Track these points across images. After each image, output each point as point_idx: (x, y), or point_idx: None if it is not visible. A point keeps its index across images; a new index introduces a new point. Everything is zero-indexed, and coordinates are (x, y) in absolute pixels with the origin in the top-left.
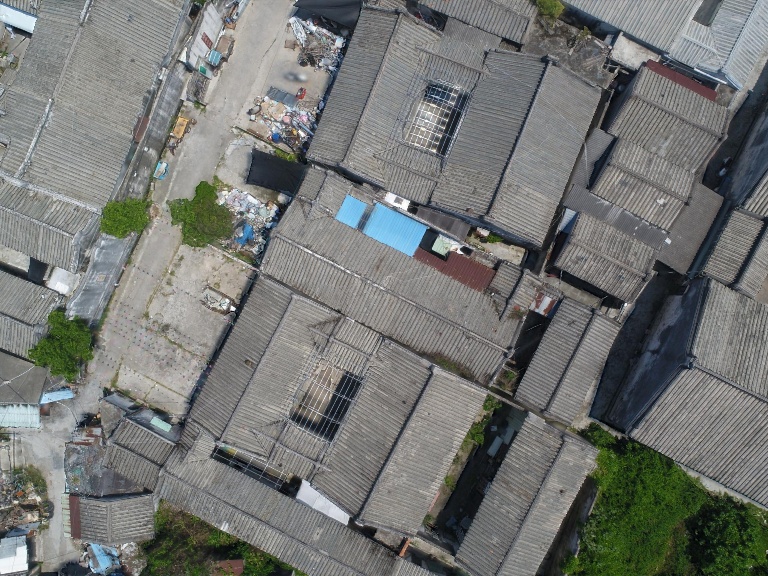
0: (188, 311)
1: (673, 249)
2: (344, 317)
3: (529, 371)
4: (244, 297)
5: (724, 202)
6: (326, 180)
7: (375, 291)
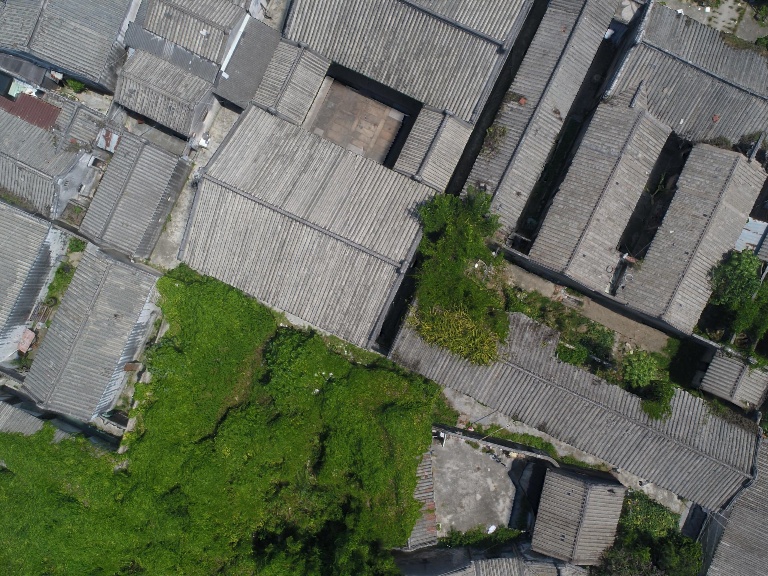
0: None
1: (232, 84)
2: None
3: (92, 204)
4: None
5: None
6: None
7: None
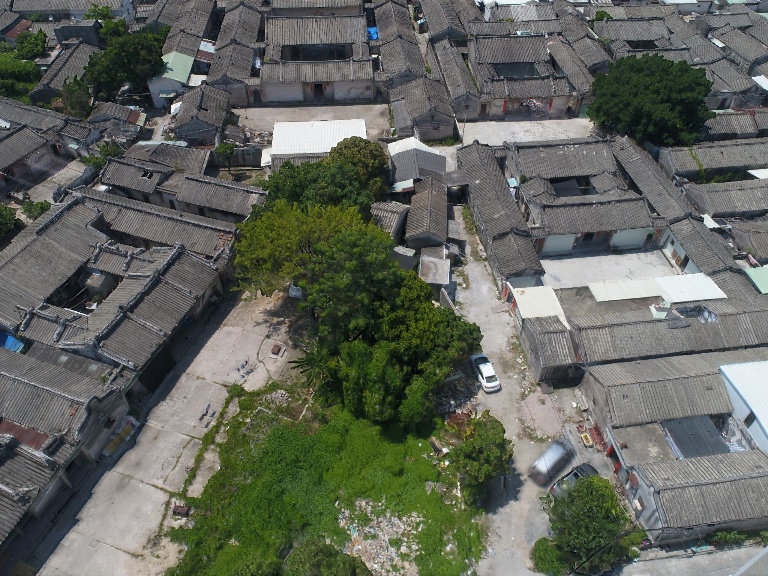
0: (47, 199)
1: None
2: None
3: None
4: (7, 204)
5: None
6: None
7: None
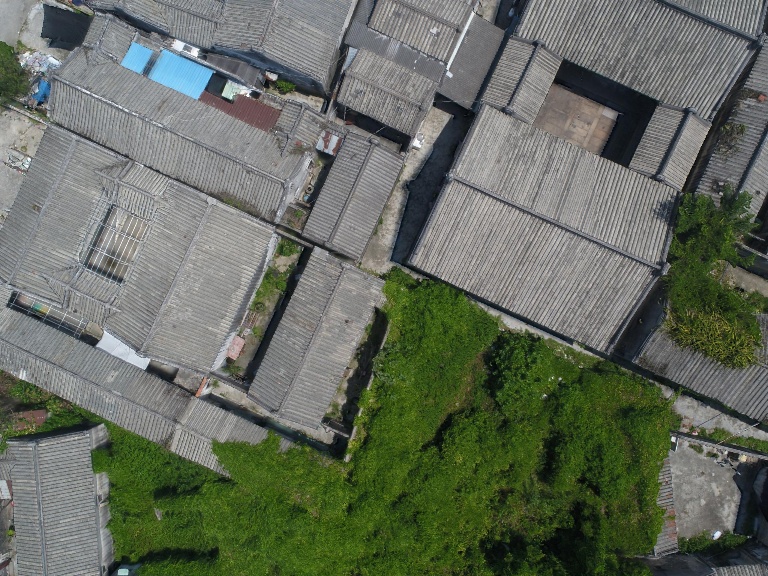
0: None
1: (455, 83)
2: (132, 162)
3: (315, 207)
4: None
5: (505, 36)
6: (105, 24)
7: (156, 130)
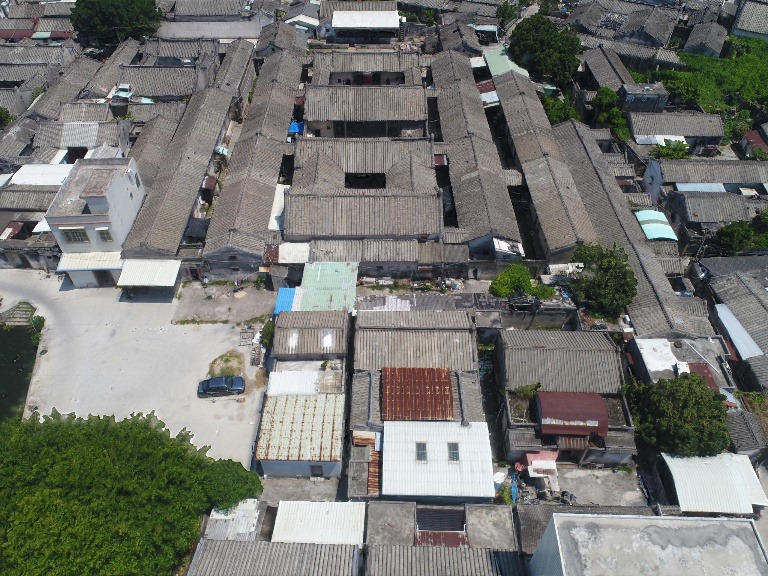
0: None
1: None
2: None
3: None
4: None
5: (738, 6)
6: None
7: (624, 3)
